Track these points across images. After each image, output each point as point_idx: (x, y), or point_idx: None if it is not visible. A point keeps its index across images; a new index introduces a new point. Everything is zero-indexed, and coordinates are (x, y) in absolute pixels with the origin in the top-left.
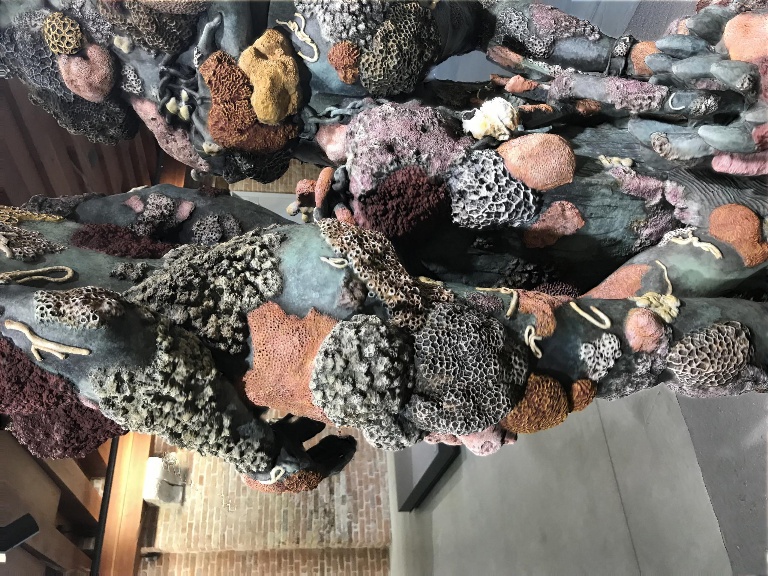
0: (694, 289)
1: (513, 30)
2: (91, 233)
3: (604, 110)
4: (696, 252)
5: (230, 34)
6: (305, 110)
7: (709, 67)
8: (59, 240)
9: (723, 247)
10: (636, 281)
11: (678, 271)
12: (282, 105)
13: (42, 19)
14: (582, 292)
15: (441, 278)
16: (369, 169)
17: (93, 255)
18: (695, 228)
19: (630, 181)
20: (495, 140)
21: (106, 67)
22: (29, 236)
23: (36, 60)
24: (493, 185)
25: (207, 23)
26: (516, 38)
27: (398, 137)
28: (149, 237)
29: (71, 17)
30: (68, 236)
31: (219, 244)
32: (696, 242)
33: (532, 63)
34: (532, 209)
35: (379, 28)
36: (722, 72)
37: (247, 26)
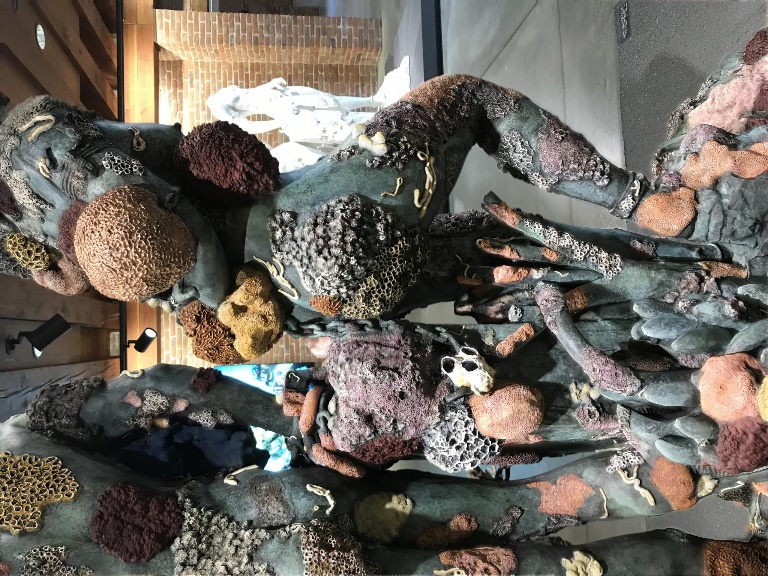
0: (626, 517)
1: (516, 163)
2: (106, 517)
3: (590, 304)
4: (635, 494)
5: (207, 298)
6: (288, 322)
7: (678, 403)
8: (80, 526)
9: (658, 496)
10: (580, 500)
11: (616, 505)
12: (265, 343)
13: (2, 232)
14: (540, 453)
15: (414, 455)
16: (348, 440)
17: (114, 572)
18: (642, 462)
19: (592, 426)
20: (470, 391)
21: (81, 281)
22: (59, 571)
23: (5, 260)
24: (462, 444)
25: (182, 294)
26: (518, 169)
27: (376, 409)
28: (150, 427)
29: (34, 241)
30: (86, 519)
31: (217, 521)
32: (637, 486)
33: (528, 228)
34: (497, 453)
35: (361, 283)
36: (684, 432)
37: (223, 285)
